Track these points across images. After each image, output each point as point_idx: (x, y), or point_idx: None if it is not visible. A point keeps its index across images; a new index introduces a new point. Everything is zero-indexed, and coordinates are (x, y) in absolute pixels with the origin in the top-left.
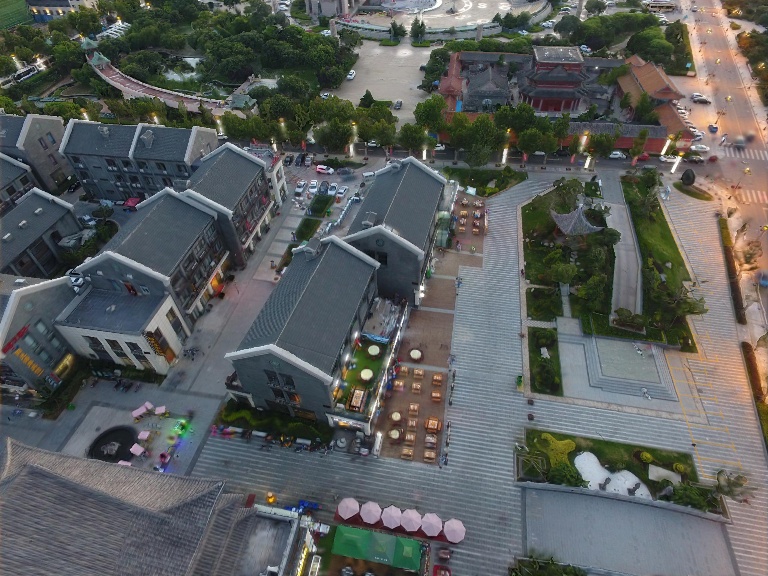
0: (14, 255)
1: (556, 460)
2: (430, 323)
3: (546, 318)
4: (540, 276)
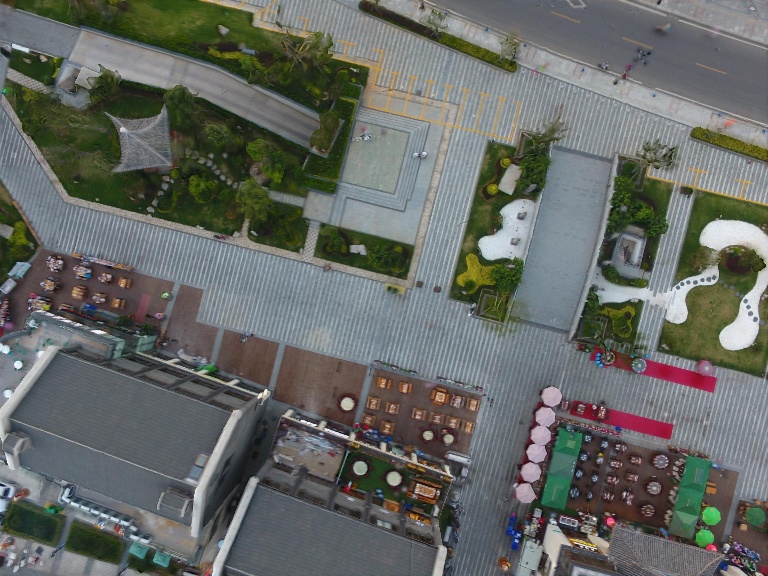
0: None
1: (488, 279)
2: (298, 378)
3: (303, 230)
4: (231, 217)
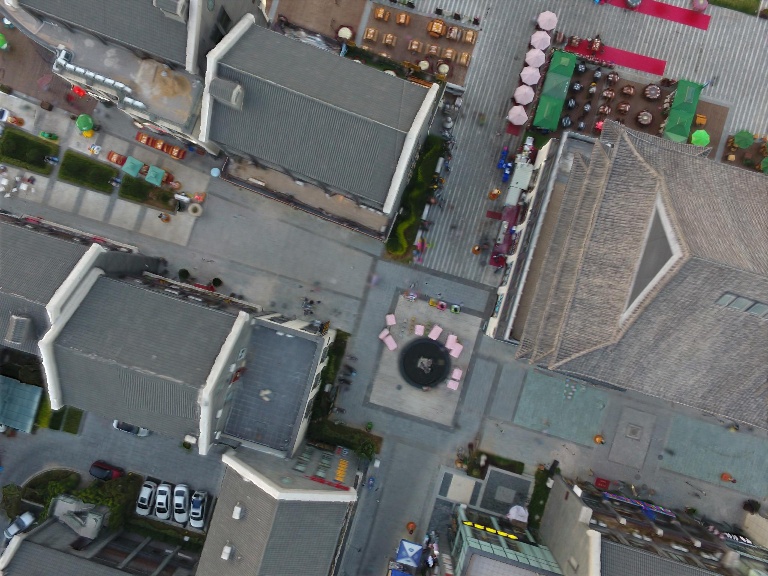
0: None
1: None
2: (297, 11)
3: None
4: None
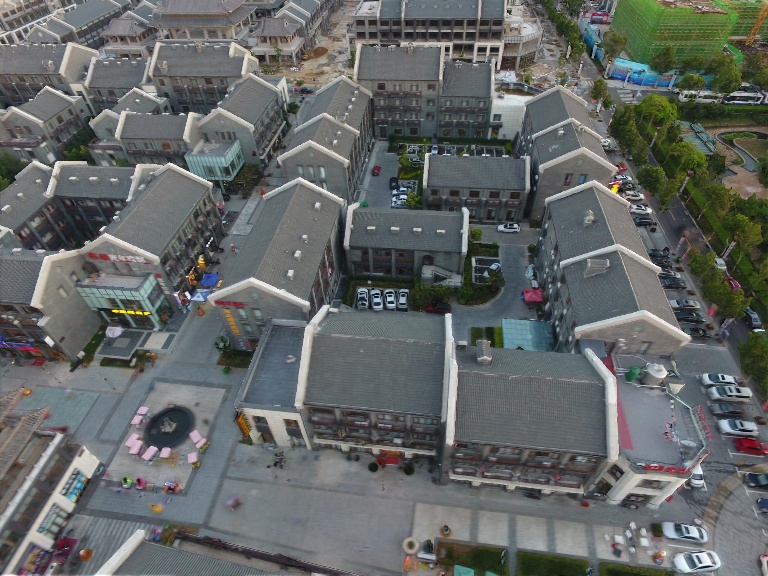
0: (380, 245)
1: None
2: None
3: None
4: None
